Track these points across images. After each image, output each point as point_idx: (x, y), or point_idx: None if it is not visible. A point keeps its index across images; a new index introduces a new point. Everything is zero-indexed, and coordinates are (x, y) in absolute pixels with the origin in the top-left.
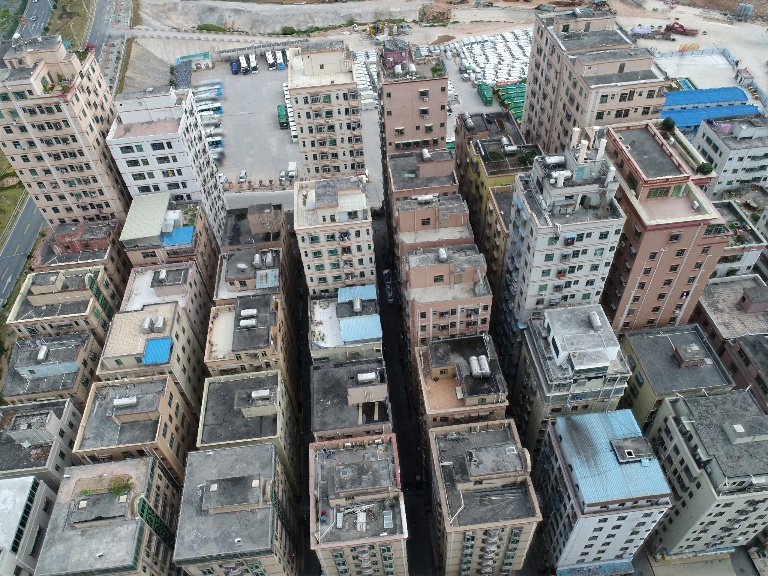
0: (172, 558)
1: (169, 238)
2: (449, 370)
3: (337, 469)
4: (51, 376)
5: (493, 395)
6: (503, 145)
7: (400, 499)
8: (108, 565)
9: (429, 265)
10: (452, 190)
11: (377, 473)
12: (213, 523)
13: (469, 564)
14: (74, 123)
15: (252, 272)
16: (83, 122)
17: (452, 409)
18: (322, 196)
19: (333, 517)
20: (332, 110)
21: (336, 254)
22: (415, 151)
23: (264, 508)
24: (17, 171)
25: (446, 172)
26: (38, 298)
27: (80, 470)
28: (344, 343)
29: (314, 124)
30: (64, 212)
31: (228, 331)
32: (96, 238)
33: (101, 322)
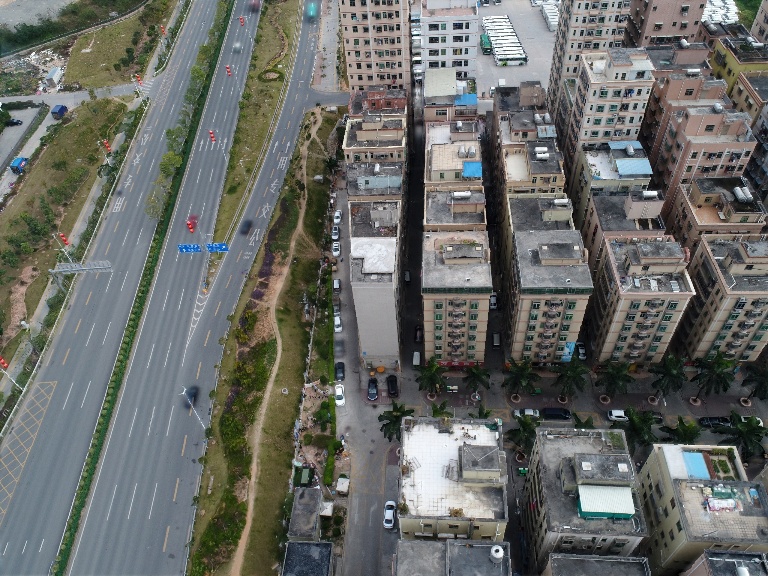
0: (520, 286)
1: (459, 100)
2: (713, 198)
3: (639, 245)
4: (378, 188)
5: (756, 214)
6: (750, 42)
7: (685, 273)
8: (475, 285)
9: (706, 114)
10: (705, 74)
11: (671, 250)
12: (546, 270)
13: (722, 341)
14: (403, 0)
15: (533, 126)
16: (407, 1)
17: (719, 223)
18: (617, 58)
19: (631, 281)
20: (608, 3)
21: (615, 110)
22: (666, 46)
23: (583, 265)
24: (345, 40)
25: (698, 61)
26: (364, 134)
27: (435, 234)
28: (619, 177)
29: (589, 15)
30: (366, 80)
31: (517, 166)
32: (398, 98)
33: (405, 159)
